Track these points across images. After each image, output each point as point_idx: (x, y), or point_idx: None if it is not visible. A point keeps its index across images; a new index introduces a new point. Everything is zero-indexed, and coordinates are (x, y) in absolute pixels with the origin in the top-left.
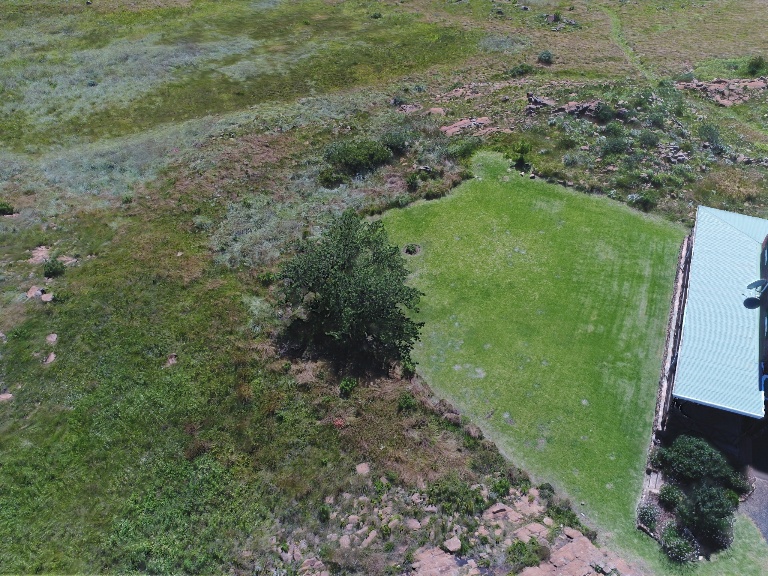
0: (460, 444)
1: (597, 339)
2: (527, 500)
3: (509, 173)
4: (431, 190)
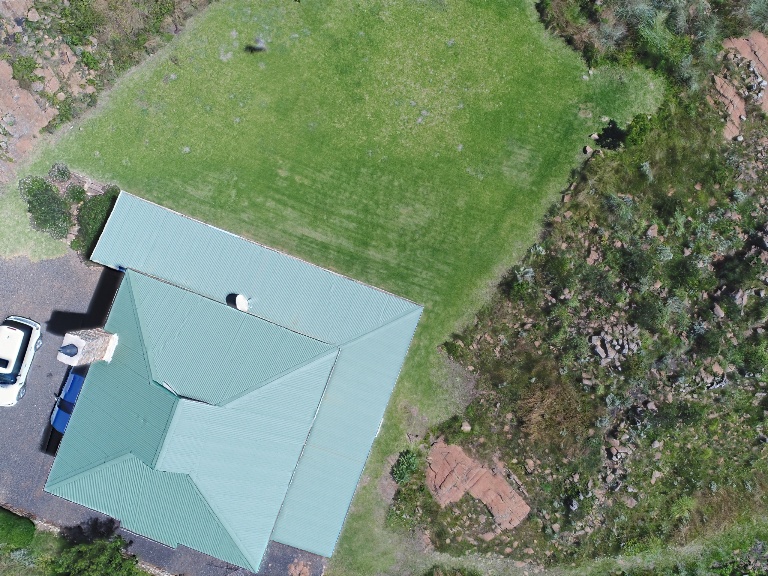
0: (137, 30)
1: (267, 177)
2: (82, 83)
3: (598, 118)
4: (549, 4)
